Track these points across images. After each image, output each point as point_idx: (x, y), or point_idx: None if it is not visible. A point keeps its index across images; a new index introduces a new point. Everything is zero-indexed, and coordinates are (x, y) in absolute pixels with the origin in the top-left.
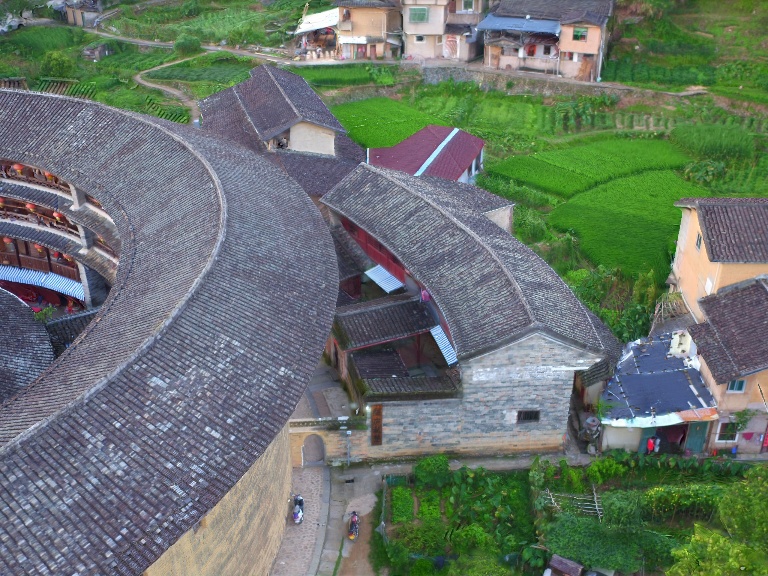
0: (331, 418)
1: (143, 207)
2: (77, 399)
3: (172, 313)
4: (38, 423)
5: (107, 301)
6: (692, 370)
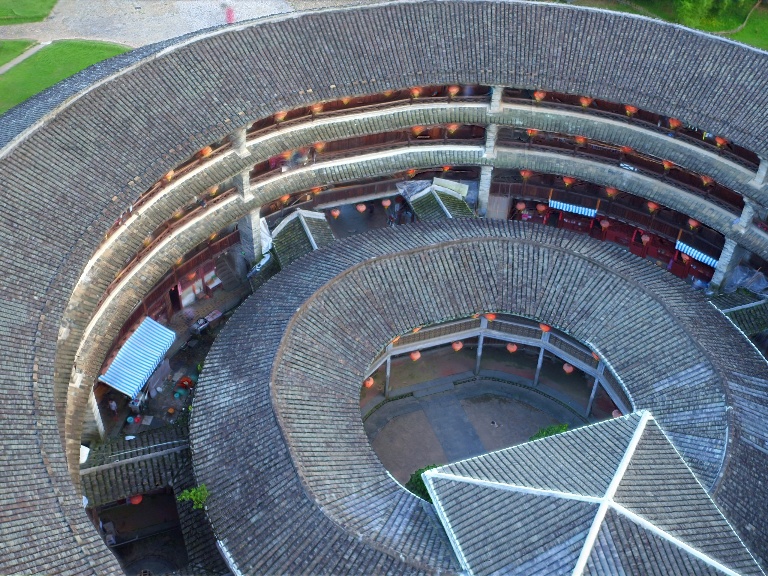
0: None
1: (7, 366)
2: (140, 60)
3: (53, 110)
4: (165, 49)
5: (102, 230)
6: None
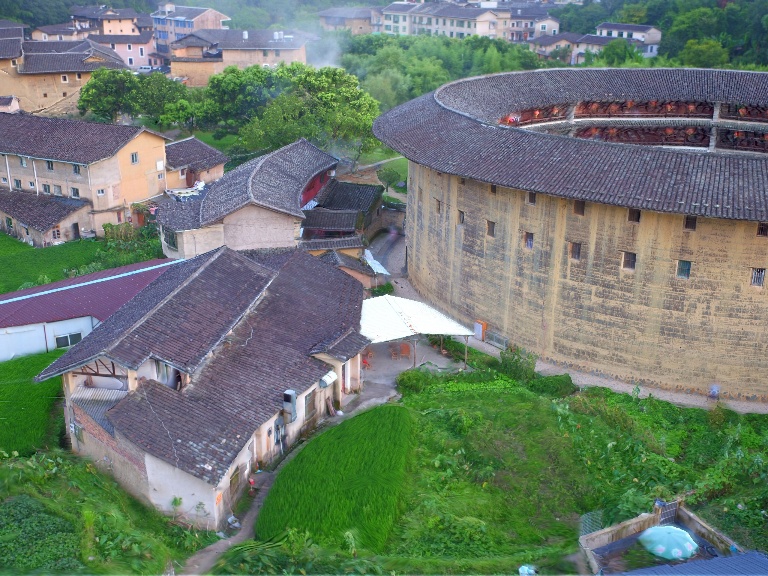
0: (401, 203)
1: None
2: None
3: None
4: None
5: None
6: (206, 187)
